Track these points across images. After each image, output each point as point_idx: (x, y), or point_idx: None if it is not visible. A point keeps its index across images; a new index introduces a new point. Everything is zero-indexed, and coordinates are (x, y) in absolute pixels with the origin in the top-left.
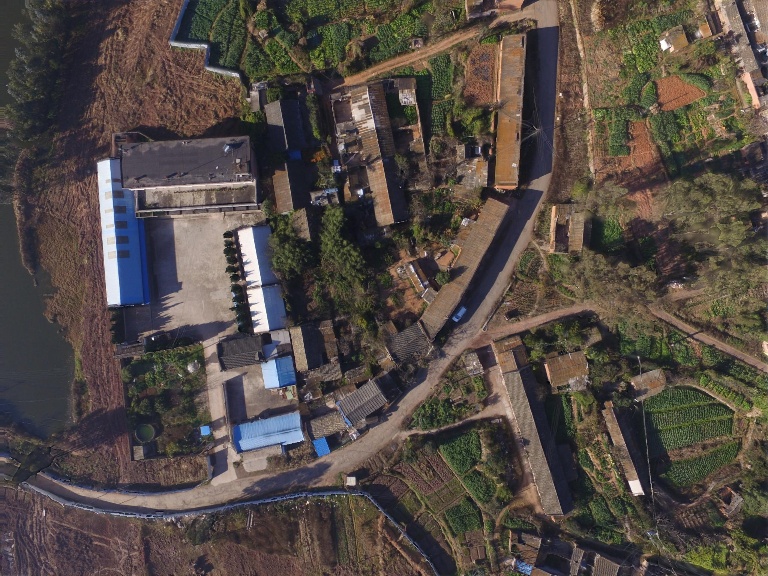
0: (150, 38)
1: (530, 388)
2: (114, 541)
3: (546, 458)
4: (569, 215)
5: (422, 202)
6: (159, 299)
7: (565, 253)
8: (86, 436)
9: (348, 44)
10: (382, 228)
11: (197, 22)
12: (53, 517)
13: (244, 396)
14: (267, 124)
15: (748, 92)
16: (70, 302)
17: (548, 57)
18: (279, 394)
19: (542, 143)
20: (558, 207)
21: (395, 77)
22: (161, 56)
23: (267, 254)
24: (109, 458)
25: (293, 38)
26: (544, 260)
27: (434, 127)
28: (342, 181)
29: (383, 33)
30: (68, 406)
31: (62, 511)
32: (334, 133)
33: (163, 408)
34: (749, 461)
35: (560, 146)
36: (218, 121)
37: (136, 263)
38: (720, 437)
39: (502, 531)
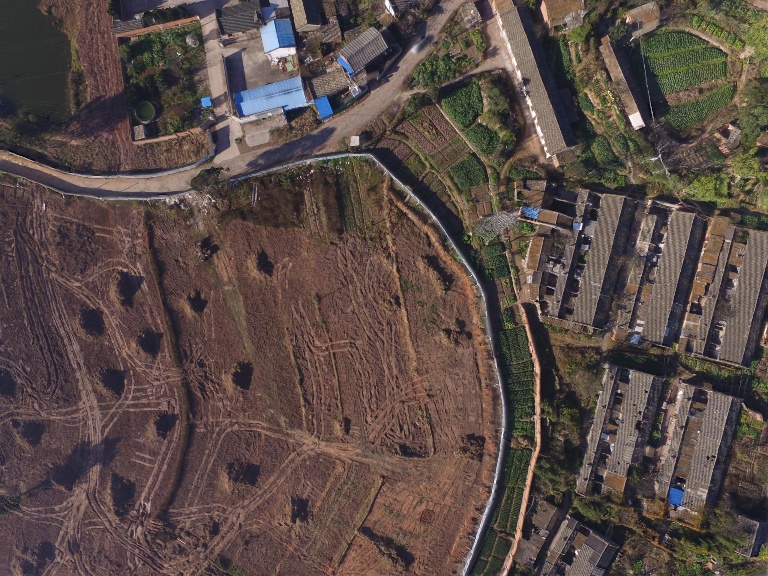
0: None
1: (528, 26)
2: (117, 230)
3: (547, 92)
4: None
5: None
6: None
7: None
8: (85, 125)
9: None
10: None
11: None
12: (53, 211)
13: (244, 72)
14: None
15: None
16: None
17: None
18: (279, 68)
19: None
20: None
21: None
22: None
23: None
24: (109, 145)
25: None
26: None
27: None
28: None
29: None
30: (66, 98)
31: (63, 203)
32: None
33: (163, 81)
34: (745, 100)
35: None
36: None
37: None
38: (715, 81)
39: (507, 183)
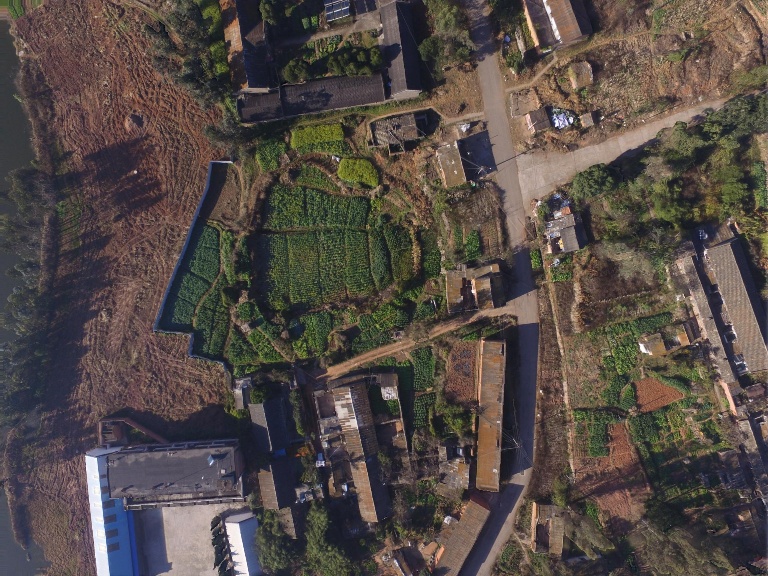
0: (134, 320)
1: None
2: None
3: None
4: (549, 517)
5: (405, 498)
6: None
7: (546, 553)
8: None
9: (330, 333)
10: (366, 523)
11: (180, 306)
12: None
13: None
14: (251, 422)
15: (726, 397)
16: None
17: (528, 353)
18: None
19: (522, 459)
20: (538, 509)
21: (377, 367)
22: (145, 339)
23: (254, 549)
24: None
25: (275, 330)
26: (525, 553)
27: (416, 421)
28: (326, 475)
29: (365, 323)
30: None
31: None
32: (318, 430)
33: None
34: None
35: (541, 442)
36: (203, 406)
37: (126, 553)
38: None
39: None
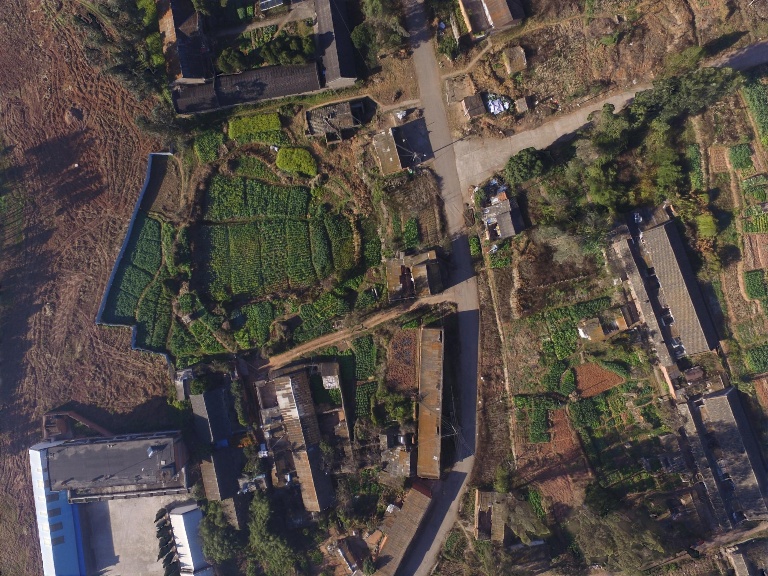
0: (77, 313)
1: None
2: None
3: None
4: (491, 504)
5: None
6: (97, 572)
7: (488, 540)
8: None
9: (272, 323)
10: (310, 512)
11: (123, 299)
12: None
13: None
14: (193, 413)
15: (665, 381)
16: (12, 571)
17: (469, 340)
18: None
19: (460, 446)
20: (480, 496)
21: (319, 357)
22: (89, 332)
23: (198, 540)
24: None
25: (217, 321)
26: (469, 541)
27: (358, 410)
28: (269, 466)
29: (306, 313)
30: None
31: None
32: (259, 420)
33: None
34: None
35: (483, 429)
36: (147, 399)
37: (71, 546)
38: None
39: None
